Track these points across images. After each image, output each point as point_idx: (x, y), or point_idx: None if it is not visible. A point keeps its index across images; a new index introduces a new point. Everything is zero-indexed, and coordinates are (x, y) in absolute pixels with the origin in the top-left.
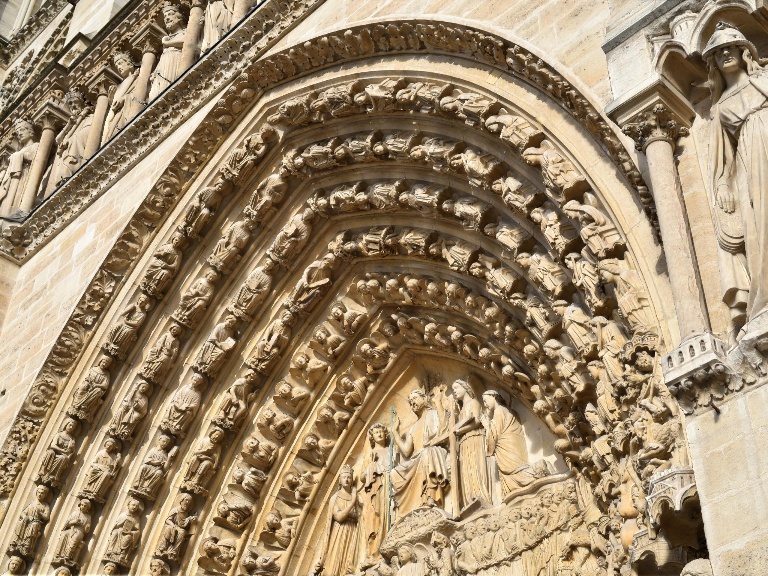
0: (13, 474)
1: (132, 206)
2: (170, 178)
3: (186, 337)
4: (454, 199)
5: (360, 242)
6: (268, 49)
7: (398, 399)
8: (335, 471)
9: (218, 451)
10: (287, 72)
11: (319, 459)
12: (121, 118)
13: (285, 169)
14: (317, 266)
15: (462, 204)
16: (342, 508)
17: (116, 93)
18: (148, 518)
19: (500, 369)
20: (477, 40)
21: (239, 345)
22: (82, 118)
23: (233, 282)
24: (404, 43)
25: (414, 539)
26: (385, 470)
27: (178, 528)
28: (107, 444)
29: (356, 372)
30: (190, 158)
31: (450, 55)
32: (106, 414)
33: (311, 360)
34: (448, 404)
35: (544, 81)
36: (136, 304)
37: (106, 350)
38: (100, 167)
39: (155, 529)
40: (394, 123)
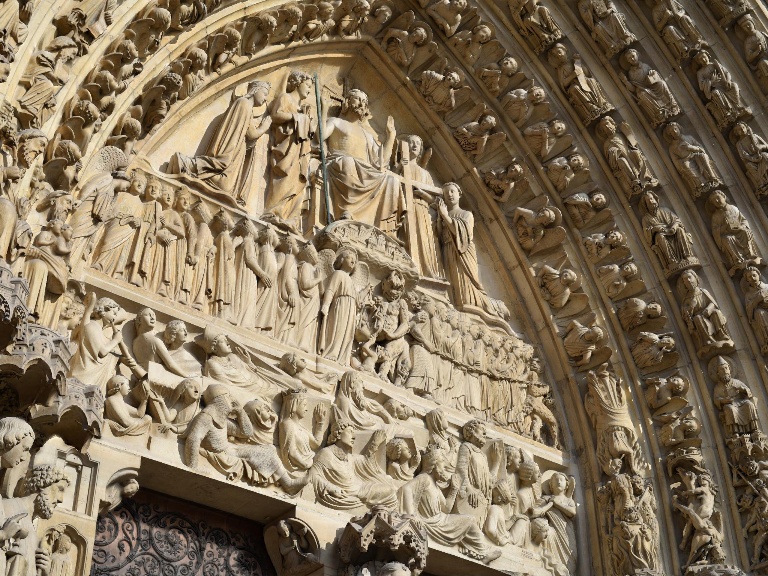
0: None
1: None
2: None
3: None
4: None
5: None
6: None
7: (318, 69)
8: None
9: None
10: None
11: (256, 45)
12: None
13: None
14: None
15: None
16: None
17: None
18: None
19: None
20: None
21: None
22: None
23: None
24: None
25: (367, 256)
26: None
27: None
28: None
29: None
30: None
31: None
32: None
33: None
34: (404, 149)
35: None
36: None
37: None
38: None
39: None
40: None
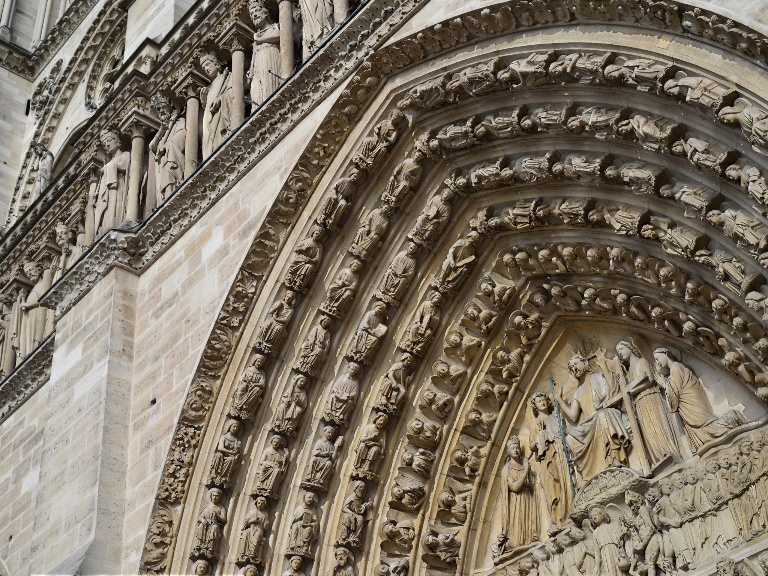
0: (182, 480)
1: (263, 205)
2: (301, 173)
3: (335, 328)
4: (617, 165)
5: (506, 217)
6: (391, 36)
7: (554, 367)
8: (500, 443)
9: (384, 436)
10: (413, 57)
11: (484, 433)
12: (221, 119)
13: (420, 153)
14: (461, 245)
15: (630, 169)
16: (516, 478)
17: (209, 94)
18: (323, 509)
19: (674, 326)
20: (644, 6)
21: (390, 330)
22: (173, 123)
23: (376, 269)
24: (550, 16)
25: (605, 500)
26: (556, 437)
27: (356, 515)
28: (274, 441)
29: (510, 345)
30: (319, 151)
31: (606, 24)
32: (266, 412)
33: (465, 337)
34: (615, 366)
35: (732, 40)
36: (283, 301)
37: (258, 349)
38: (216, 169)
39: (332, 519)
40: (542, 96)
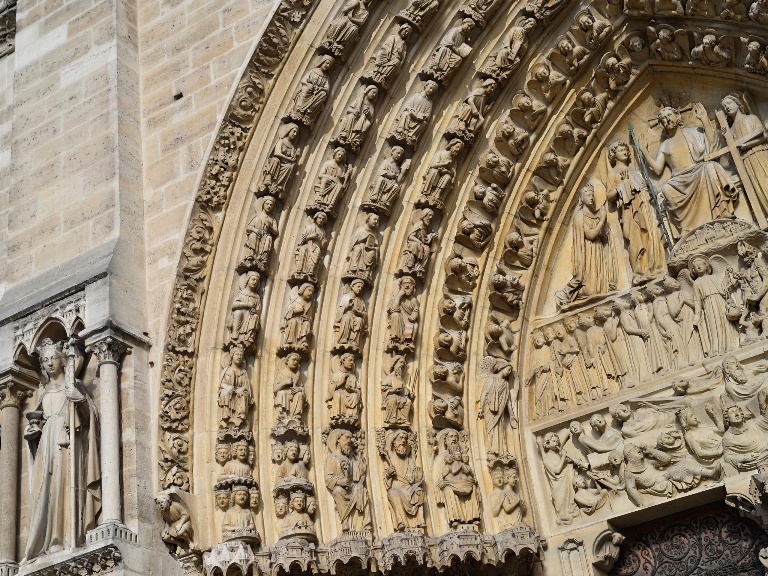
0: (225, 184)
1: None
2: None
3: (411, 41)
4: None
5: None
6: None
7: (633, 118)
8: (569, 190)
9: (455, 165)
10: None
11: (557, 177)
12: None
13: None
14: None
15: None
16: (591, 226)
17: None
18: (384, 234)
19: None
20: None
21: (472, 53)
22: None
23: None
24: None
25: (712, 251)
26: (641, 187)
27: (423, 244)
28: (338, 153)
29: (596, 87)
30: None
31: None
32: (325, 122)
33: (552, 72)
34: (719, 120)
35: None
36: None
37: None
38: None
39: (393, 246)
40: None
